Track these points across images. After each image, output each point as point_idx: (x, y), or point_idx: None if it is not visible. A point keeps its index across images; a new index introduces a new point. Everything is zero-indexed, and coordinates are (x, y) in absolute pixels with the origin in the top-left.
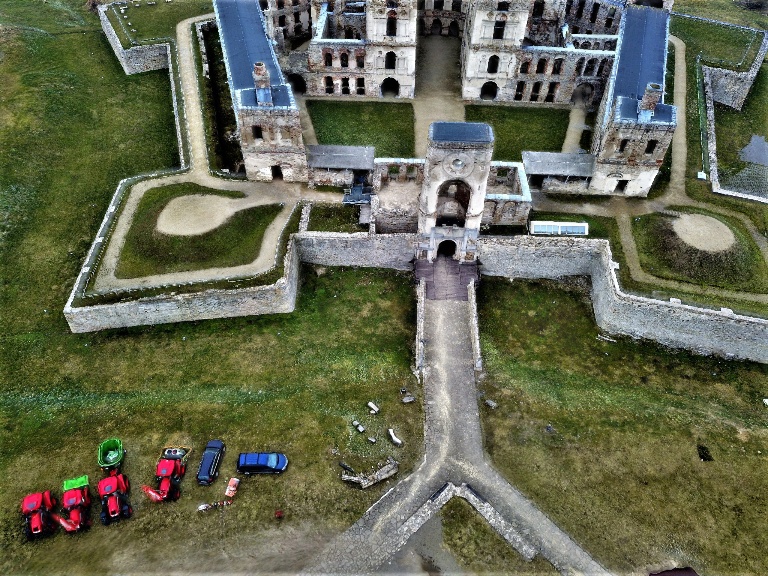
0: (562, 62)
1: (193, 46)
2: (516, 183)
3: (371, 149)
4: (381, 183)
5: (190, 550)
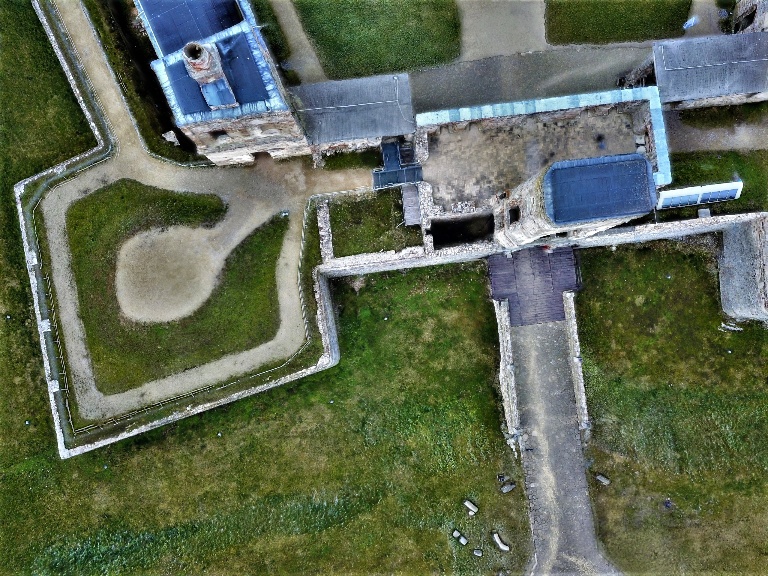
0: None
1: None
2: (643, 125)
3: (403, 81)
4: None
5: None
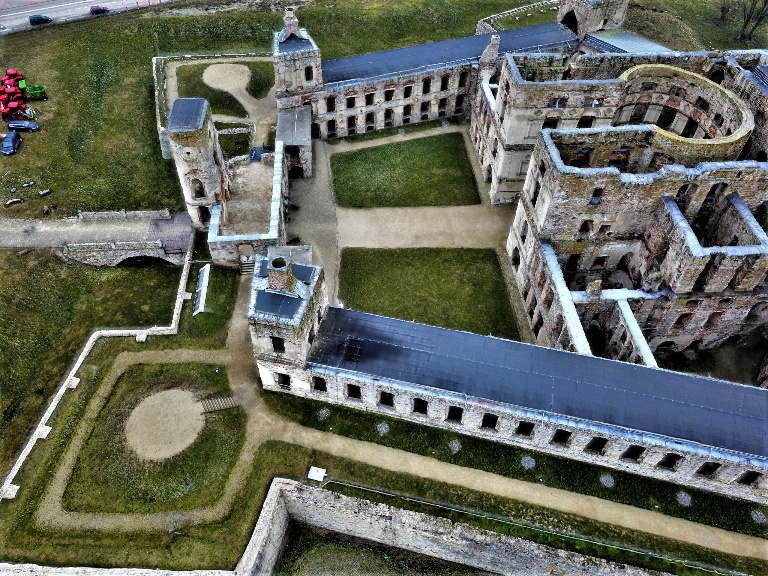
0: None
1: None
2: None
3: (306, 142)
4: None
5: None
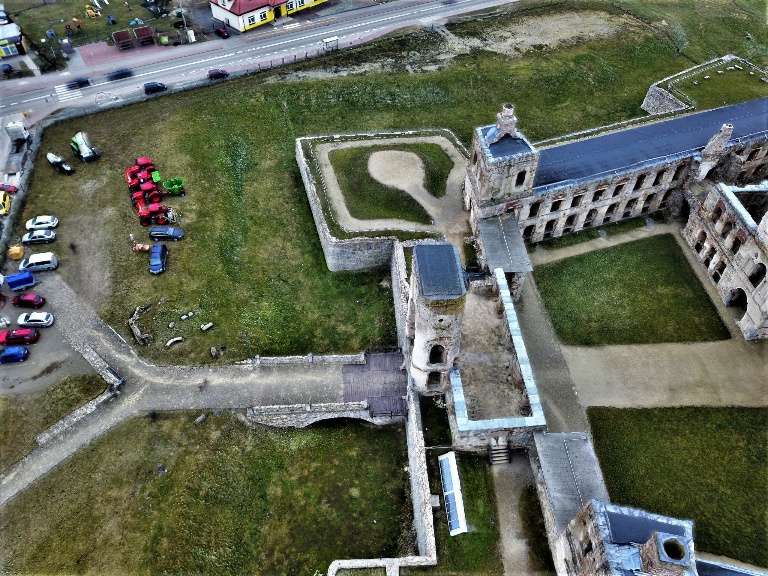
0: None
1: None
2: None
3: (527, 267)
4: (488, 293)
5: (106, 238)
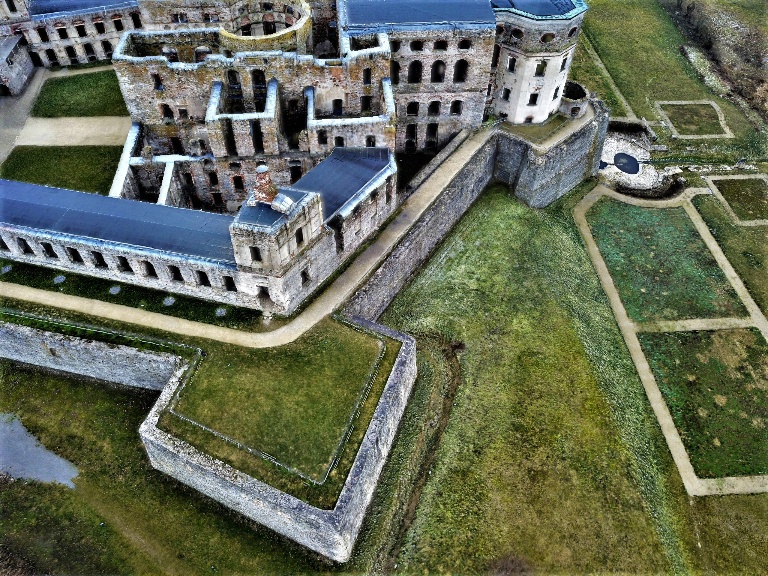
0: None
1: None
2: None
3: None
4: None
5: None
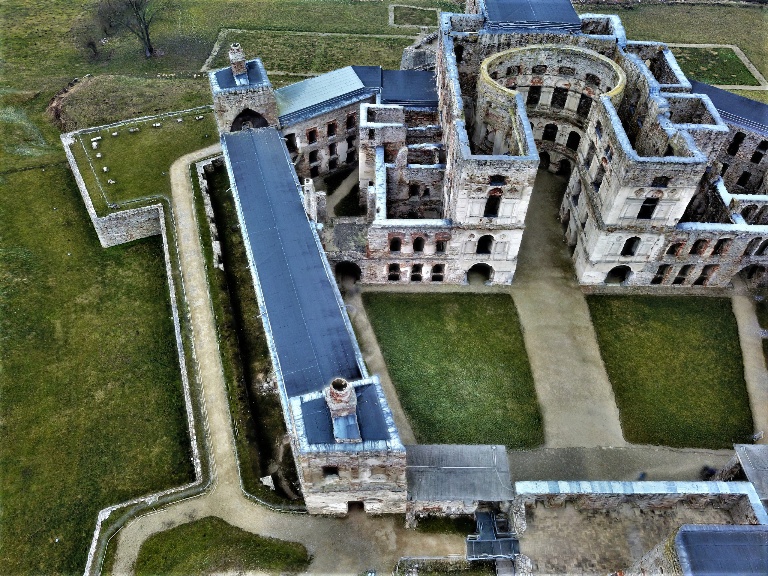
0: (727, 241)
1: (196, 208)
2: (746, 520)
3: (501, 451)
4: None
5: None
